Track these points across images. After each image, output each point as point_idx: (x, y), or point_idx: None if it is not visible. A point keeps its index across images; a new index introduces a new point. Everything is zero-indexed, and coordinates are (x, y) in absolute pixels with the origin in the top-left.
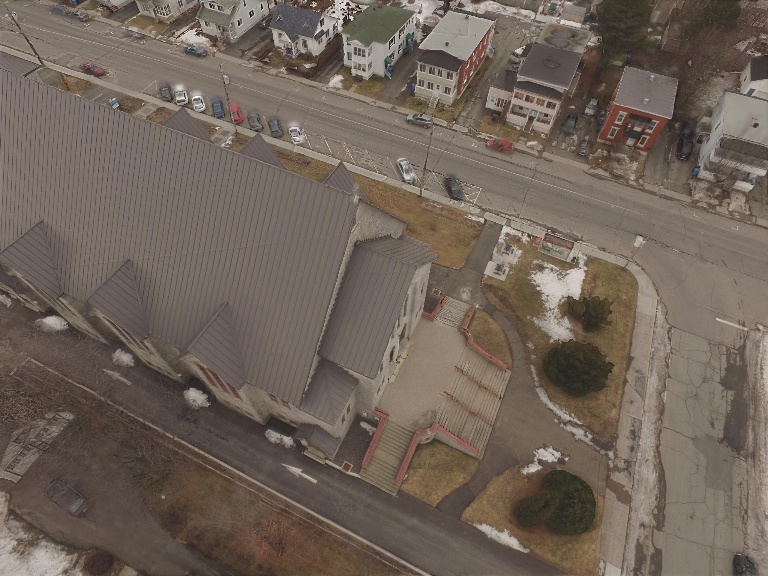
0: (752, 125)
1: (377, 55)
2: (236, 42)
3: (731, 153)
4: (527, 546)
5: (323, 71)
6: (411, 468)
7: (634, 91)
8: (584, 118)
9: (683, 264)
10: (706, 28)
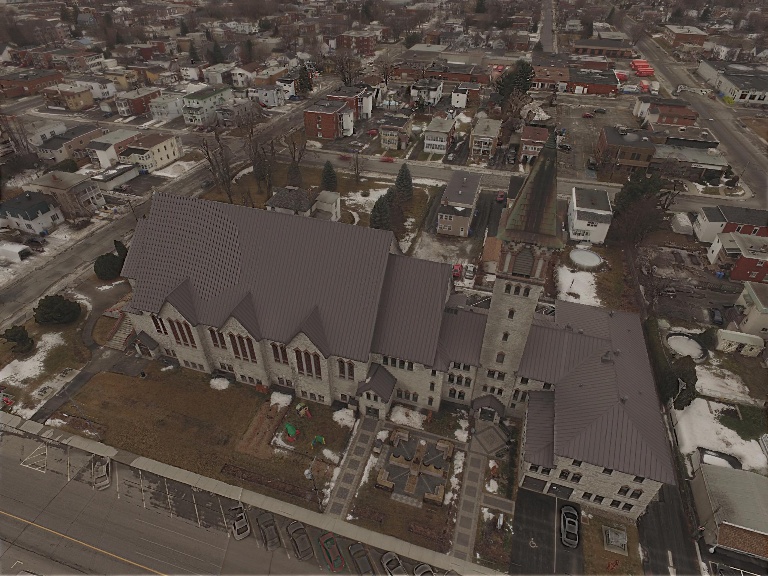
0: None
1: None
2: None
3: None
4: None
5: None
6: None
7: None
8: None
9: None
10: None
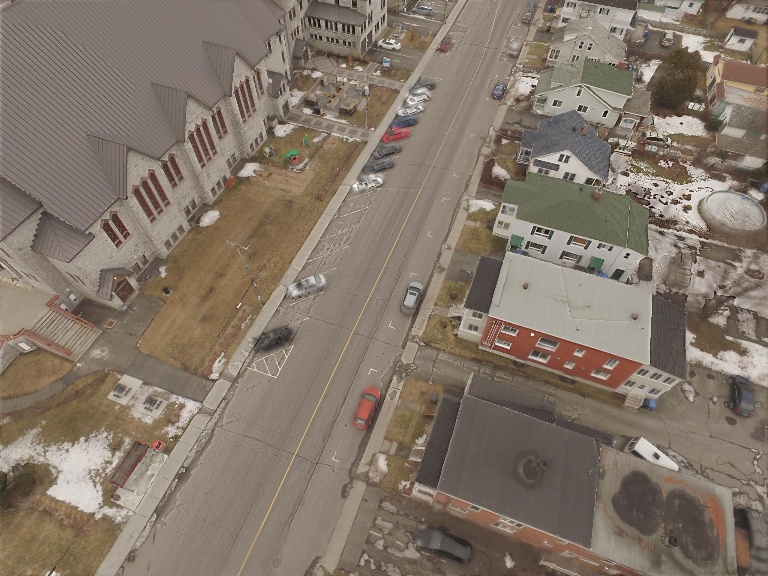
0: None
1: None
2: (524, 111)
3: None
4: None
5: (500, 191)
6: None
7: None
8: None
9: None
10: None
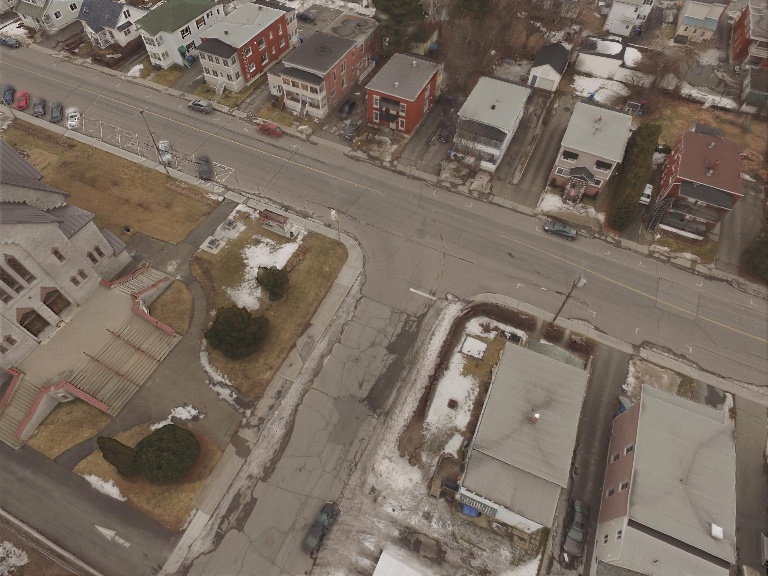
0: (491, 107)
1: (170, 44)
2: (50, 34)
3: (467, 134)
4: (126, 495)
5: (127, 61)
6: (43, 424)
7: (392, 76)
8: (364, 104)
9: (400, 239)
10: (458, 15)
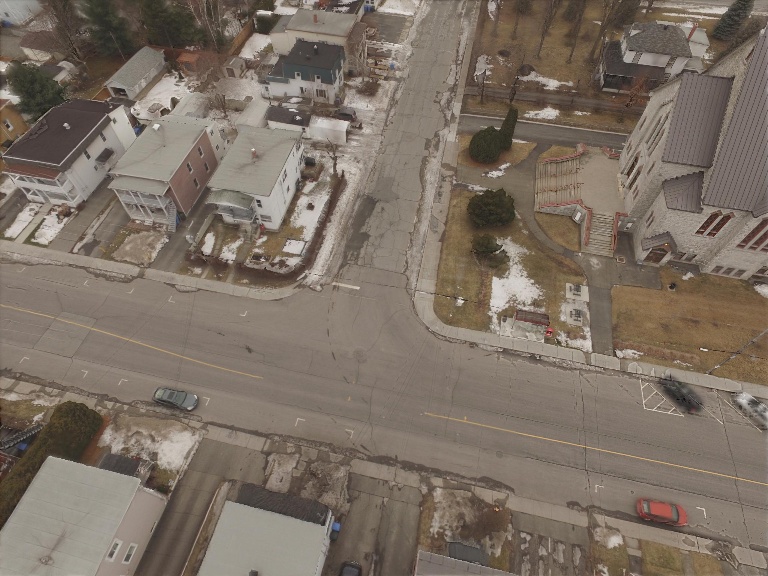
0: None
1: None
2: None
3: None
4: None
5: None
6: None
7: None
8: None
9: (383, 344)
10: None
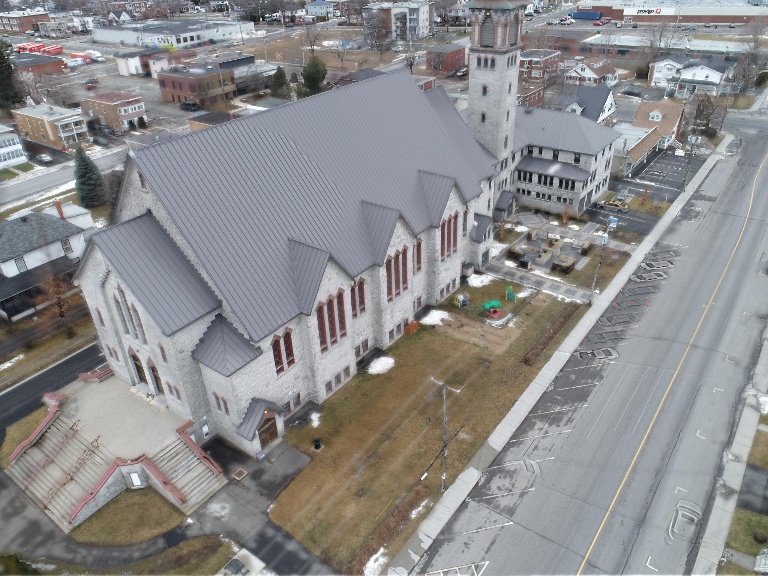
0: None
1: None
2: None
3: None
4: None
5: None
6: None
7: None
8: None
9: None
10: None
